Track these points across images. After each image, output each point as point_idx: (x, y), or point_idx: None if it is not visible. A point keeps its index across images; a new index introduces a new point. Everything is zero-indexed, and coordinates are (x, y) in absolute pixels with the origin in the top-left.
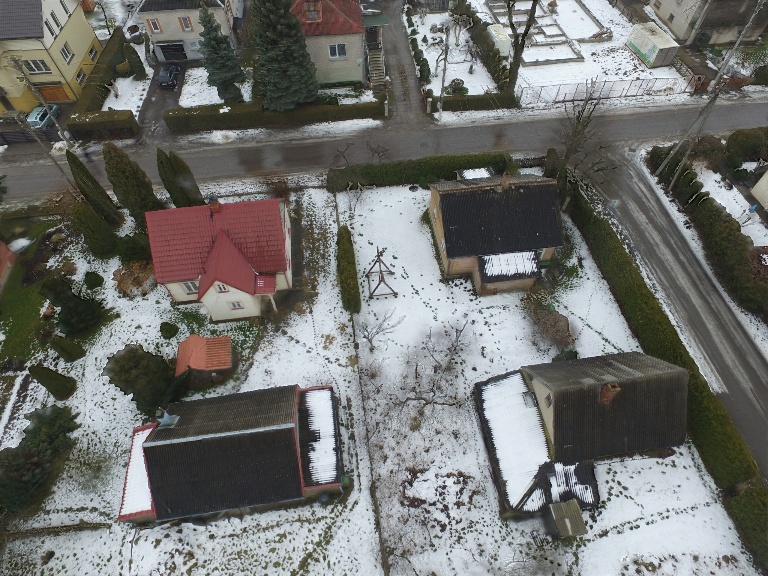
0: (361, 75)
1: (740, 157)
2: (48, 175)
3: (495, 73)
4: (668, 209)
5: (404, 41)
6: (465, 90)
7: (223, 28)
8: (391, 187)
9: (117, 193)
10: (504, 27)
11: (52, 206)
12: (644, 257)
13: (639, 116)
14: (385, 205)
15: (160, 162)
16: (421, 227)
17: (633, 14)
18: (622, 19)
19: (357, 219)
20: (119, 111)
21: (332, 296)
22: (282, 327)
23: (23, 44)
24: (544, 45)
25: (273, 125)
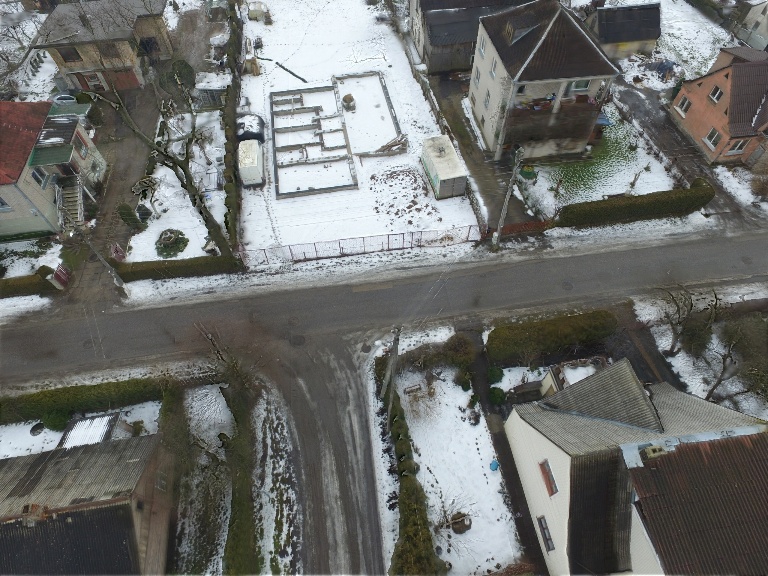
0: (47, 224)
1: (507, 359)
2: None
3: None
4: (376, 468)
5: (144, 158)
6: (182, 243)
7: None
8: (7, 427)
9: None
10: (279, 133)
11: None
12: (307, 574)
13: (396, 284)
14: None
15: None
16: None
17: (438, 115)
18: (430, 118)
19: None
20: None
21: None
22: None
23: None
24: (317, 163)
25: None
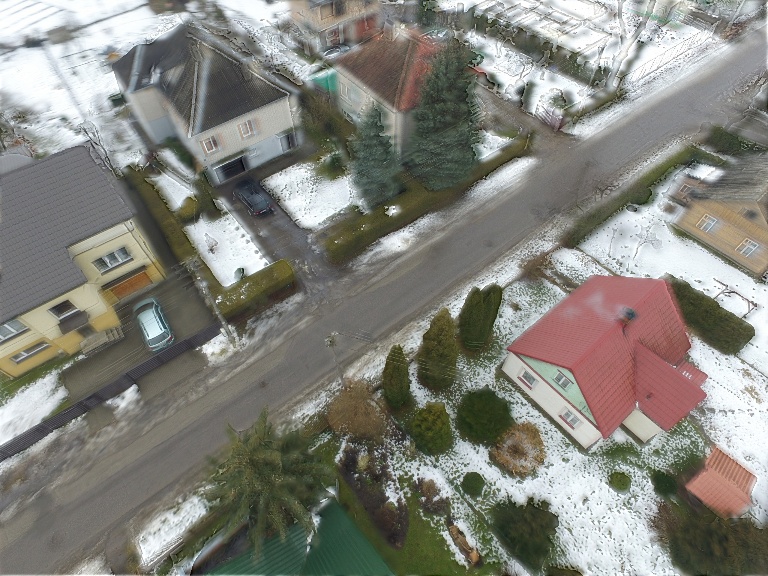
0: None
1: None
2: (244, 392)
3: (568, 72)
4: None
5: None
6: (561, 97)
7: (286, 119)
8: (613, 216)
9: (436, 365)
10: None
11: (302, 427)
12: None
13: (704, 70)
14: (630, 236)
15: (482, 302)
16: (682, 241)
17: None
18: None
19: (625, 262)
20: (271, 267)
21: (700, 349)
22: (703, 406)
23: (97, 238)
24: (567, 33)
25: (434, 205)
